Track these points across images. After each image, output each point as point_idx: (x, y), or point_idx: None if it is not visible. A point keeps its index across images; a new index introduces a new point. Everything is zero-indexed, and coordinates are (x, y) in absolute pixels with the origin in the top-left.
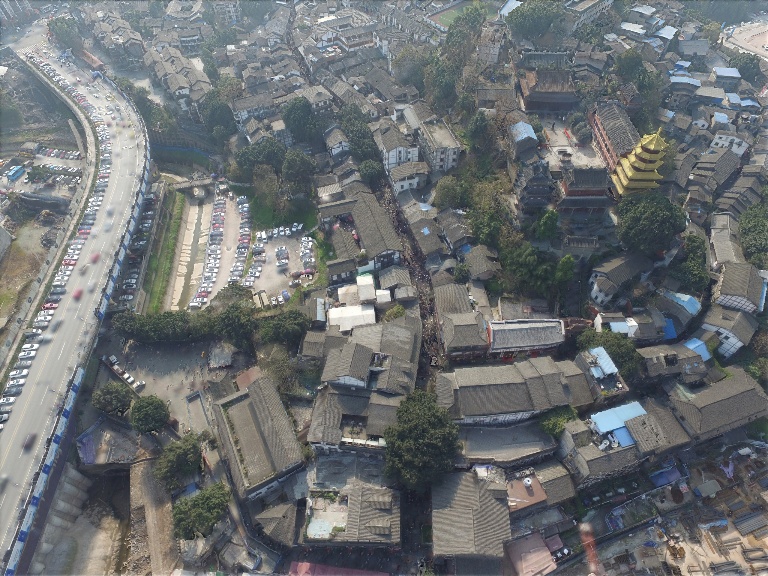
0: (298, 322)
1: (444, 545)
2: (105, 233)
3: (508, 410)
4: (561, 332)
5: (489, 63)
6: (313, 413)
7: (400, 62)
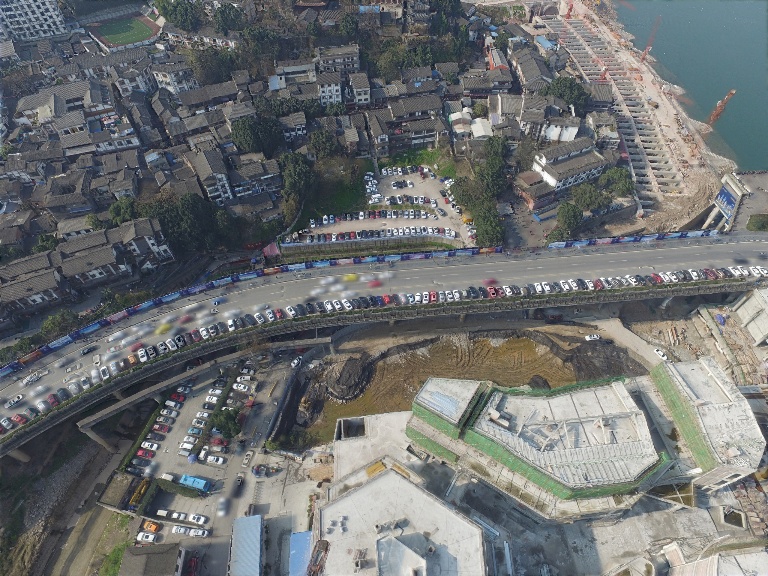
0: (498, 137)
1: (609, 96)
2: (387, 282)
3: (546, 68)
4: (498, 50)
5: (253, 18)
6: (564, 125)
7: (206, 64)
